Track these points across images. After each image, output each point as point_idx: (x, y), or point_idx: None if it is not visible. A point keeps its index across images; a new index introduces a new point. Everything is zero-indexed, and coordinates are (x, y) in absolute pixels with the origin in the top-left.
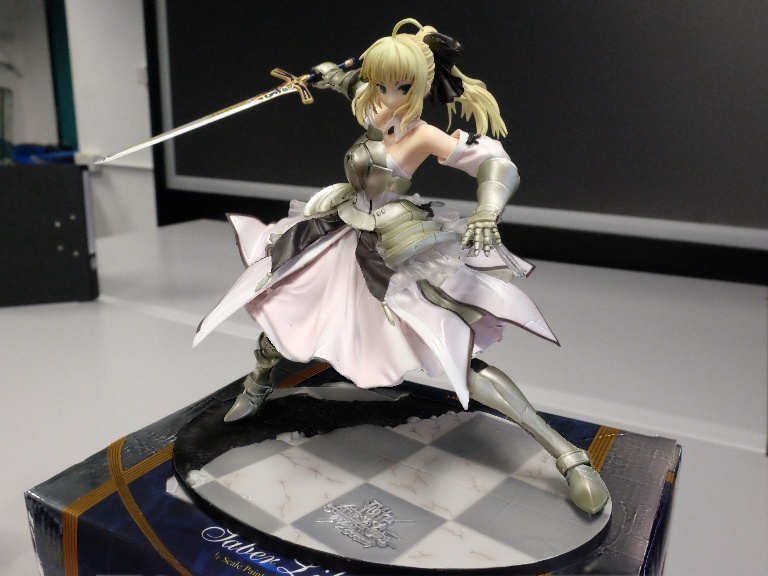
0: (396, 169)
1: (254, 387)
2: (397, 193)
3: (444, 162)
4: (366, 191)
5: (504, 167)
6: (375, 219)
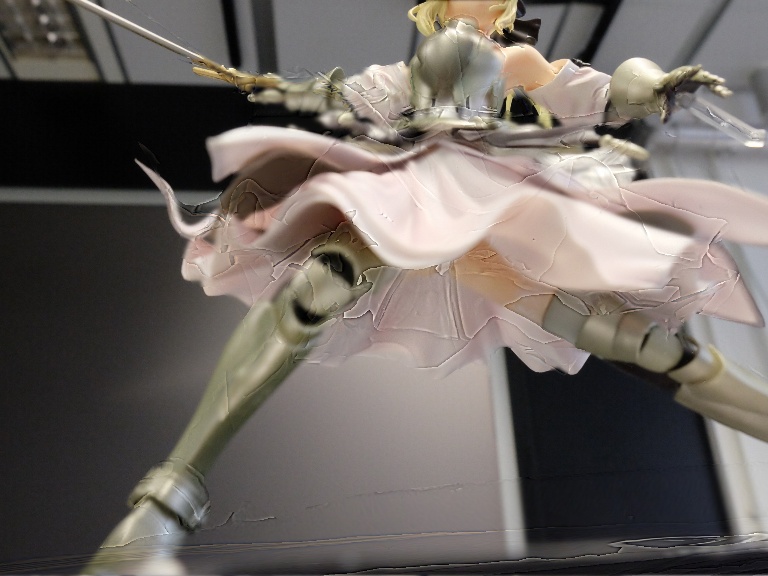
0: (502, 65)
1: (184, 479)
2: (496, 105)
3: (551, 81)
4: (463, 82)
5: (646, 73)
6: (490, 110)
